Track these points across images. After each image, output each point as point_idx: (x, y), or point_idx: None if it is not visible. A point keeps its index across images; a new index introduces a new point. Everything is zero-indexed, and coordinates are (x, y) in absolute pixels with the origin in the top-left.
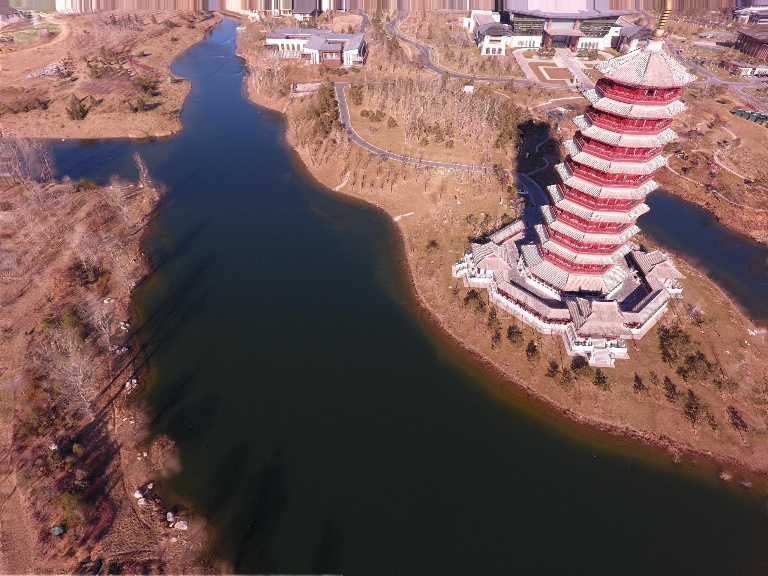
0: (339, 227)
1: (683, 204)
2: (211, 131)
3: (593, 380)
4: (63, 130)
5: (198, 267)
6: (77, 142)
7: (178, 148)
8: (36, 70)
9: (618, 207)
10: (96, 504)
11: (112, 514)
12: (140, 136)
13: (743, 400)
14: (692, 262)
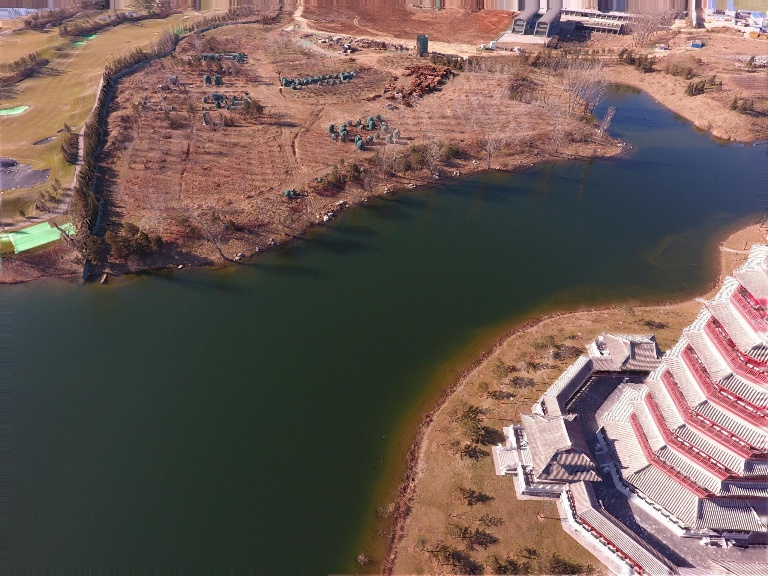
0: (648, 258)
1: None
2: (766, 159)
3: (463, 434)
4: (668, 96)
5: (531, 189)
6: (660, 107)
7: (710, 150)
8: (743, 55)
9: (702, 376)
10: (335, 189)
11: (330, 195)
12: (701, 126)
13: None
14: None
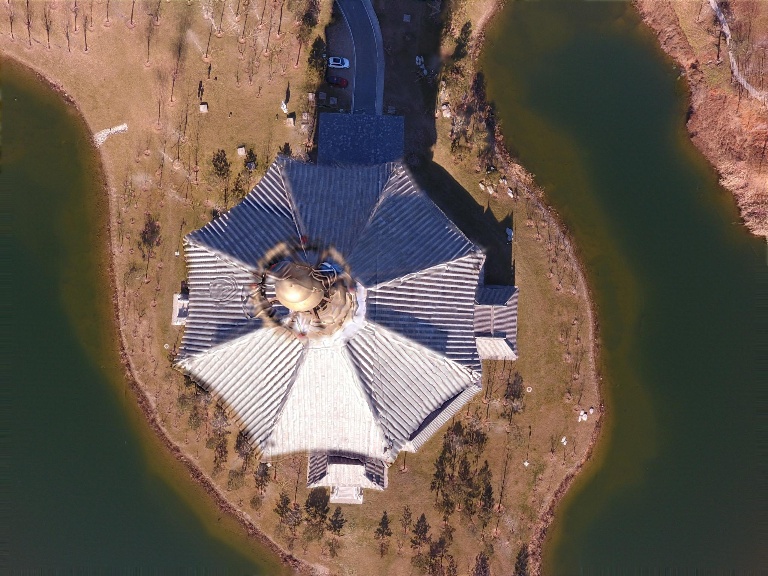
0: None
1: (654, 58)
2: None
3: None
4: None
5: None
6: None
7: None
8: None
9: None
10: None
11: None
12: None
13: (506, 539)
14: (583, 244)
